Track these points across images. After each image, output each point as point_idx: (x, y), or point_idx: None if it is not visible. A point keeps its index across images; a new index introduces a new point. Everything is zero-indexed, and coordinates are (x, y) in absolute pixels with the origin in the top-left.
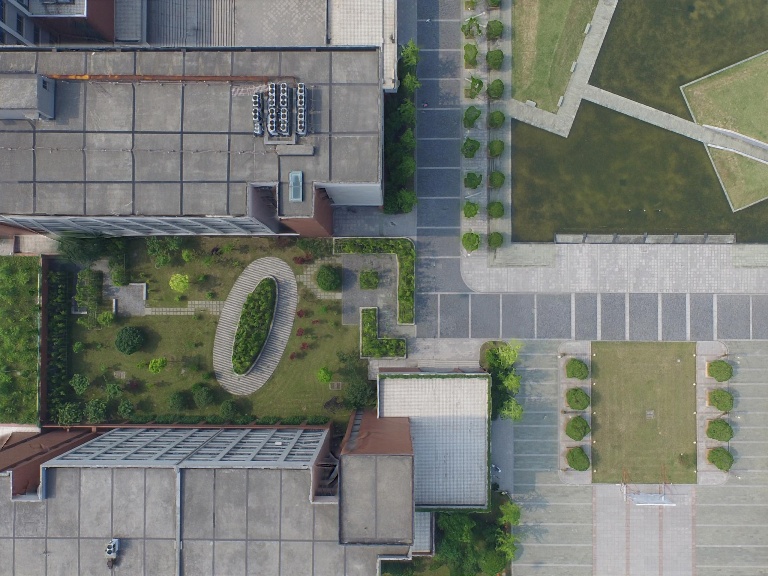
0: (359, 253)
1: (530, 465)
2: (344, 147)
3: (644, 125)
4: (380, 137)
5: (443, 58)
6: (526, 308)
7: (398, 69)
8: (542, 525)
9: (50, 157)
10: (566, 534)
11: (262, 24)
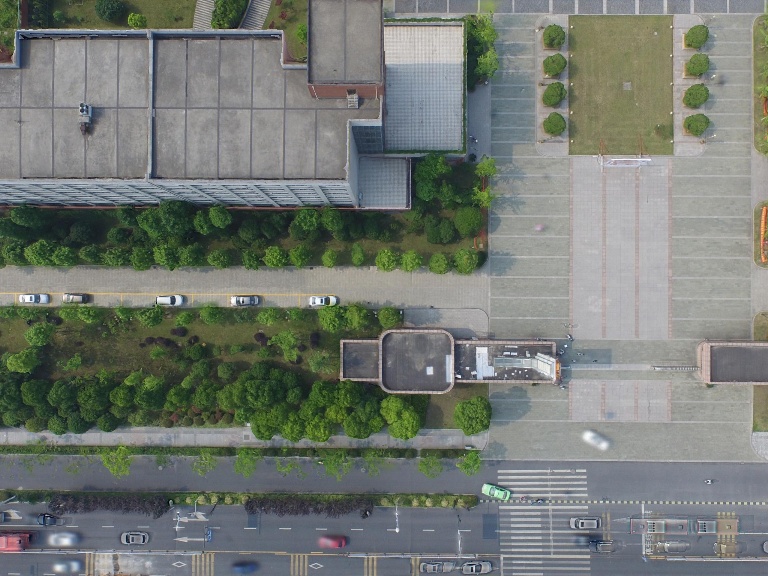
0: None
1: (507, 138)
2: None
3: None
4: None
5: None
6: None
7: None
8: (519, 197)
9: None
10: (543, 205)
11: None
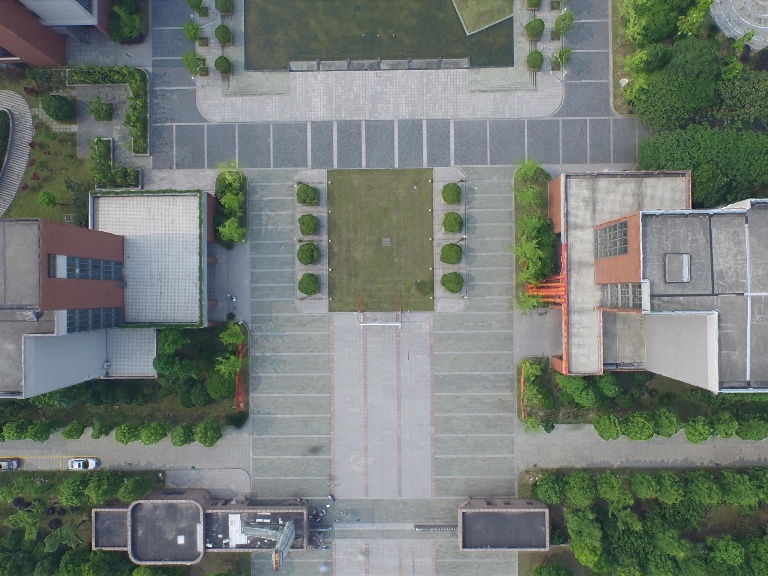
0: (87, 80)
1: (267, 295)
2: None
3: None
4: None
5: None
6: (262, 137)
7: None
8: (280, 355)
9: None
10: (304, 364)
11: None
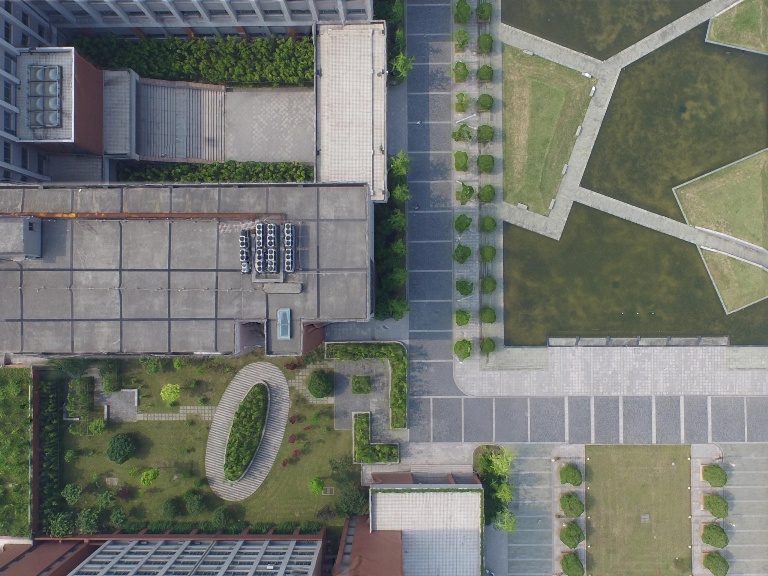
0: (351, 360)
1: (524, 570)
2: (332, 284)
3: (636, 227)
4: (368, 274)
5: (434, 160)
6: (519, 411)
7: (388, 179)
8: None
9: (37, 295)
10: None
11: (252, 127)
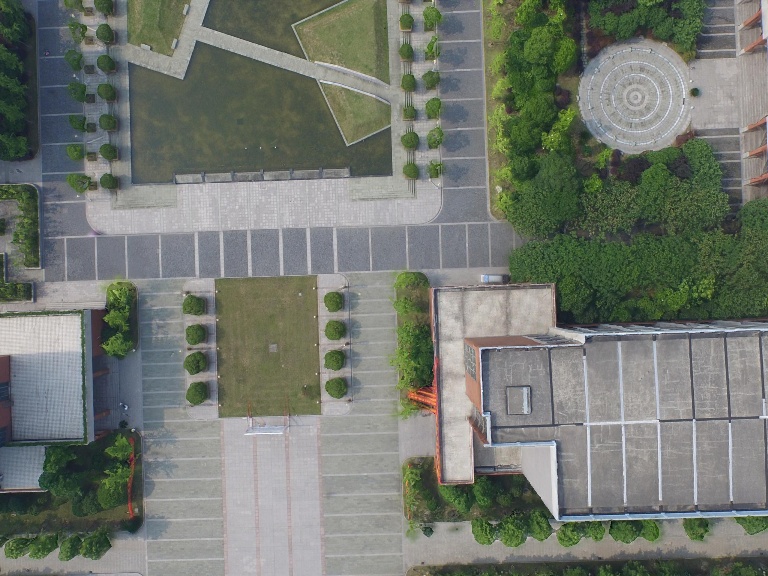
0: None
1: (159, 402)
2: None
3: (259, 64)
4: None
5: (63, 7)
6: (151, 248)
7: None
8: (172, 460)
9: None
10: (196, 468)
11: None
